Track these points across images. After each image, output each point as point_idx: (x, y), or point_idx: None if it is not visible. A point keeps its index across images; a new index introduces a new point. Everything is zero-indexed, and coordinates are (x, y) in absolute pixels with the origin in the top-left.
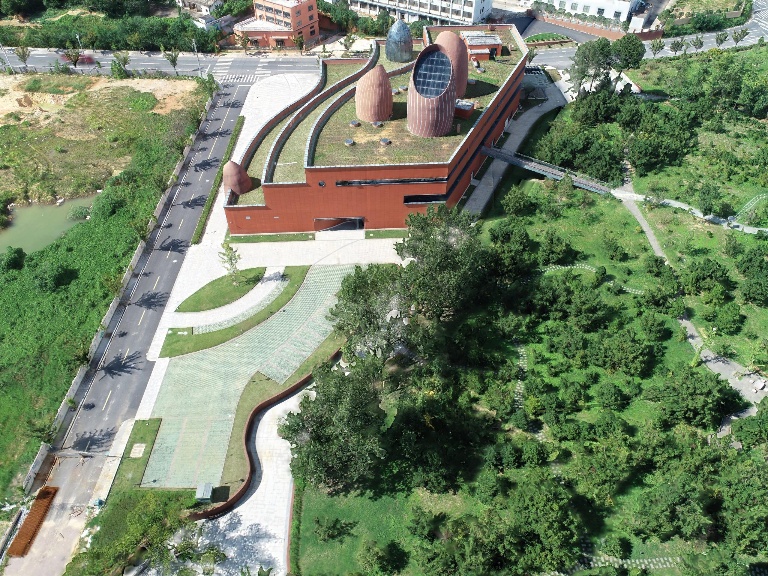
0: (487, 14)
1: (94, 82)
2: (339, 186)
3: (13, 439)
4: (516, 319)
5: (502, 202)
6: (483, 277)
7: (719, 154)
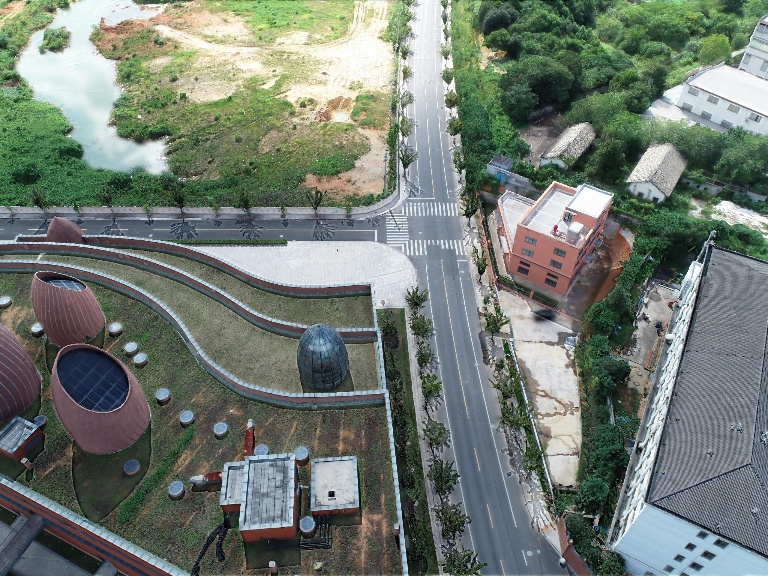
0: None
1: (377, 128)
2: None
3: None
4: None
5: None
6: None
7: None
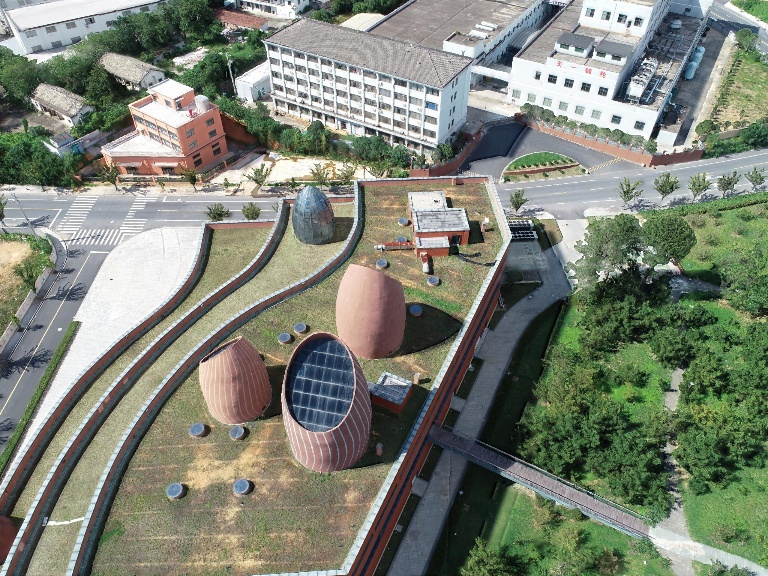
0: (459, 125)
1: None
2: None
3: None
4: None
5: None
6: None
7: None
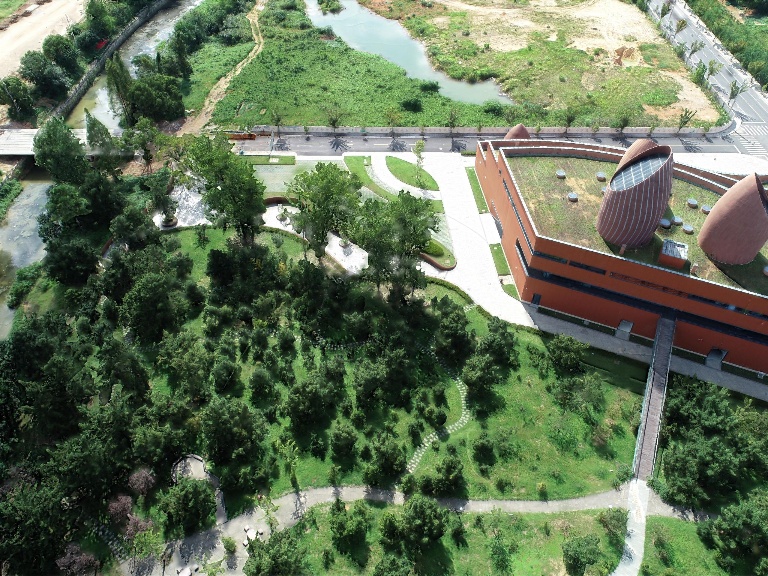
0: None
1: (676, 70)
2: None
3: (287, 120)
4: (351, 317)
5: (555, 334)
6: (416, 304)
7: None
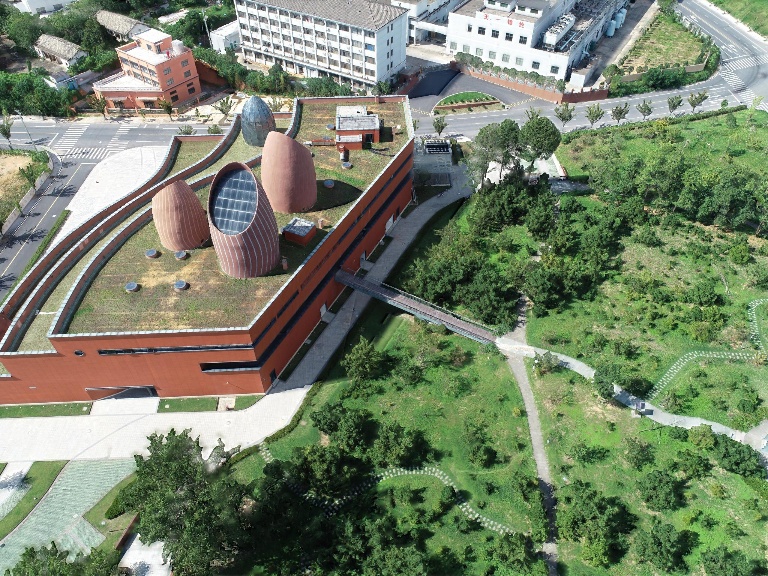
0: (399, 69)
1: None
2: (104, 355)
3: None
4: None
5: (342, 363)
6: (277, 505)
7: (644, 285)
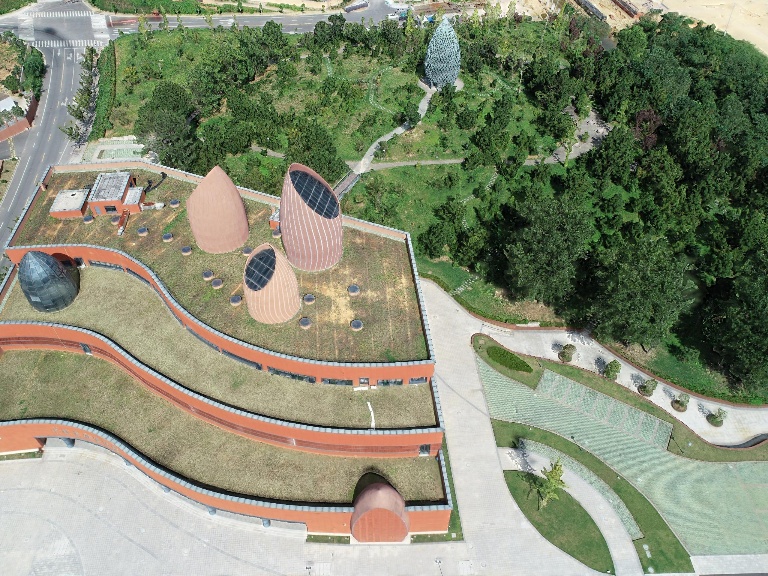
0: None
1: None
2: None
3: None
4: None
5: None
6: None
7: None
